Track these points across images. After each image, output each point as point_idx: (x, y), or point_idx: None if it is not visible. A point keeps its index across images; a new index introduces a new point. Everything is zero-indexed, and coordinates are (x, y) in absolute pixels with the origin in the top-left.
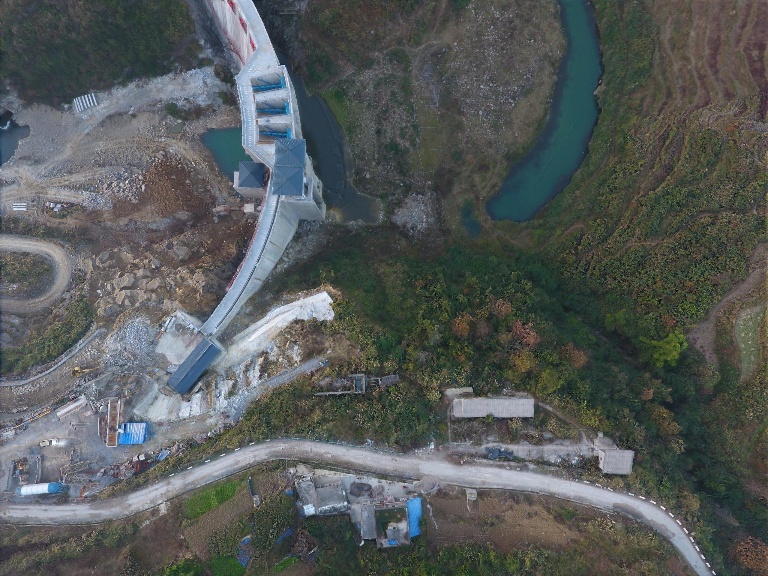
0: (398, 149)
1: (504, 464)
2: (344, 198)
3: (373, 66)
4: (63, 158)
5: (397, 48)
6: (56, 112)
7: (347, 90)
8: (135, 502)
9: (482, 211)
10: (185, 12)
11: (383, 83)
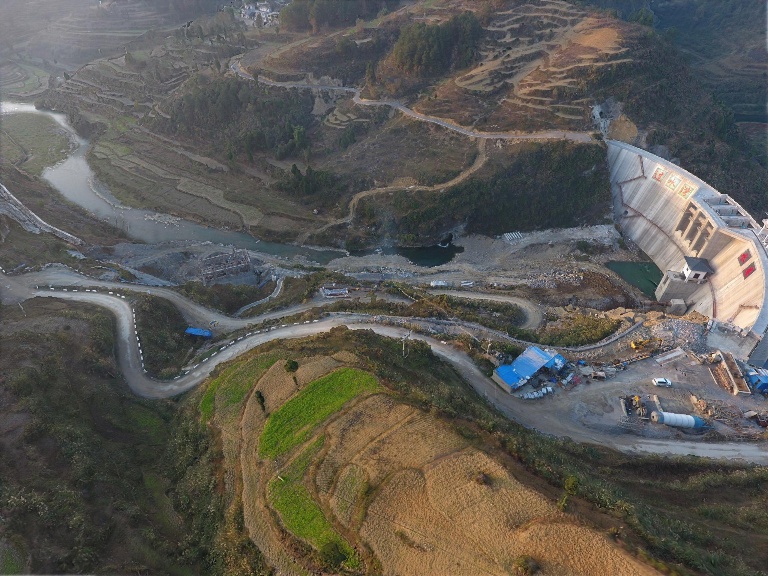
0: None
1: None
2: None
3: None
4: (494, 264)
5: None
6: (489, 240)
7: None
8: None
9: None
10: (608, 187)
11: None
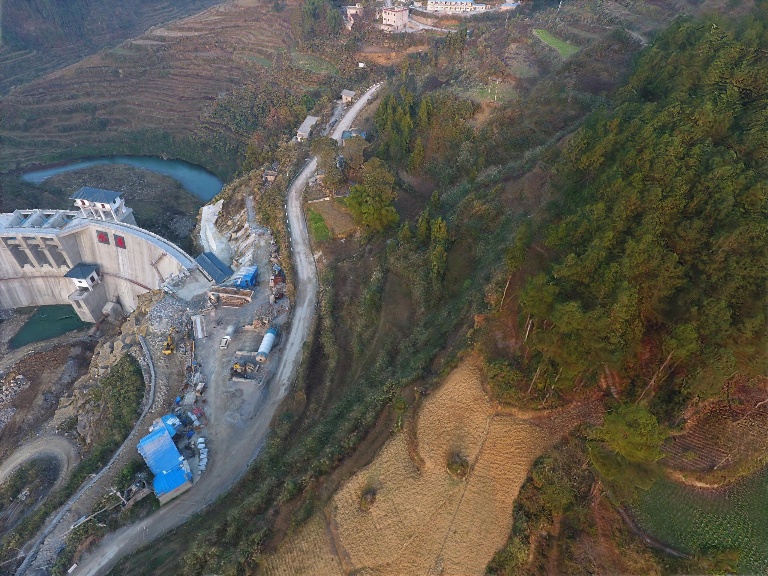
0: None
1: (338, 121)
2: None
3: None
4: None
5: None
6: None
7: None
8: (307, 274)
9: (206, 202)
10: None
11: None
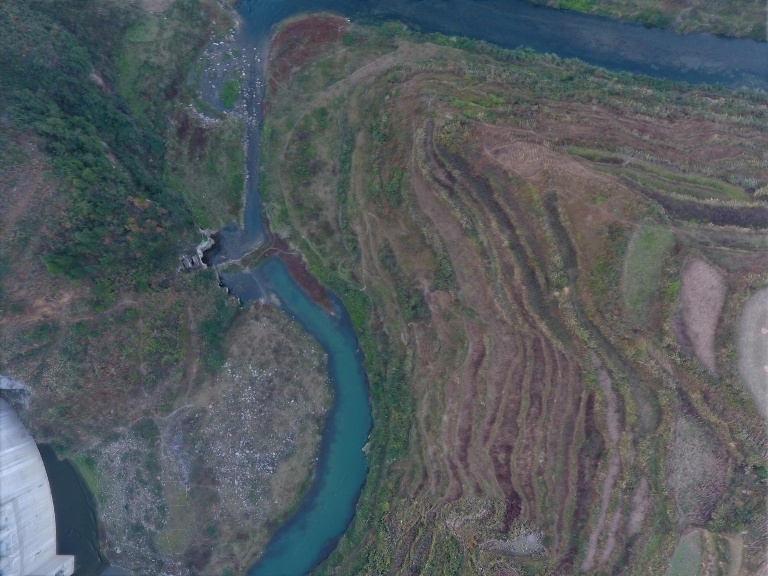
0: (143, 533)
1: None
2: (101, 565)
3: (119, 439)
4: None
5: (144, 419)
6: None
7: (95, 460)
8: None
9: None
10: None
11: (129, 458)
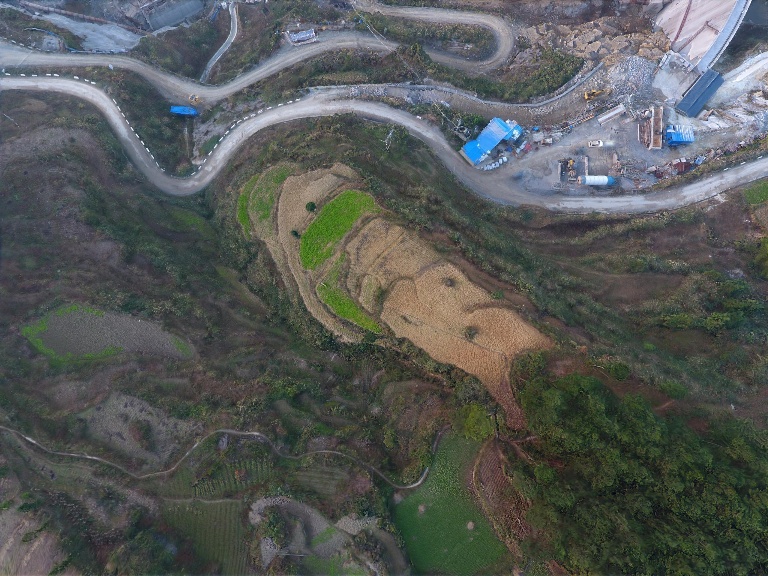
0: None
1: None
2: None
3: None
4: None
5: None
6: None
7: None
8: (690, 194)
9: None
10: None
11: None
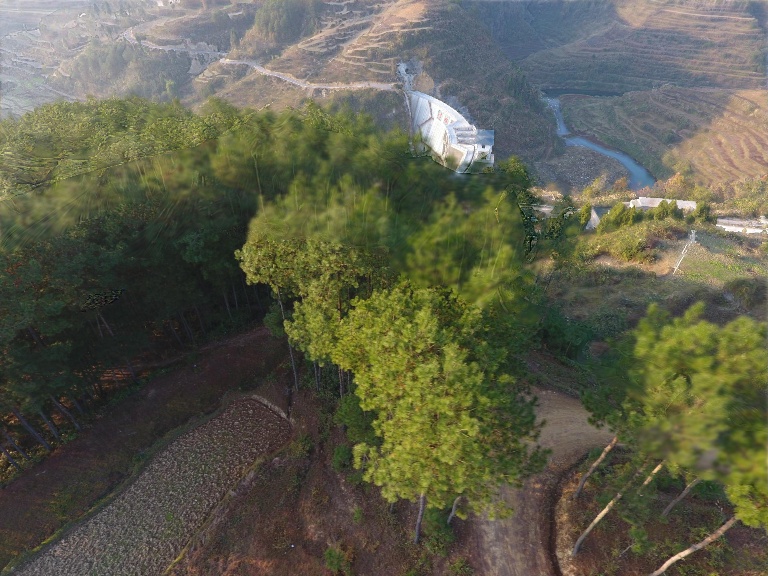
0: None
1: None
2: None
3: None
4: None
5: None
6: None
7: None
8: None
9: None
10: (408, 127)
11: None
